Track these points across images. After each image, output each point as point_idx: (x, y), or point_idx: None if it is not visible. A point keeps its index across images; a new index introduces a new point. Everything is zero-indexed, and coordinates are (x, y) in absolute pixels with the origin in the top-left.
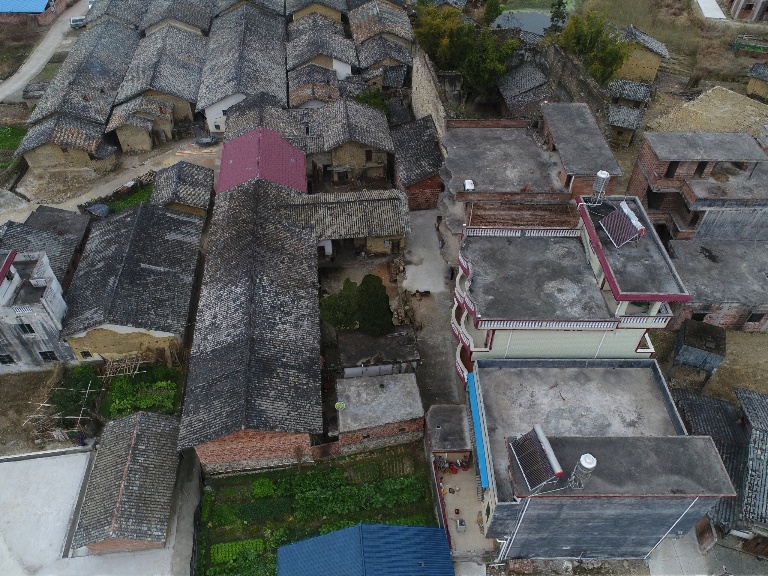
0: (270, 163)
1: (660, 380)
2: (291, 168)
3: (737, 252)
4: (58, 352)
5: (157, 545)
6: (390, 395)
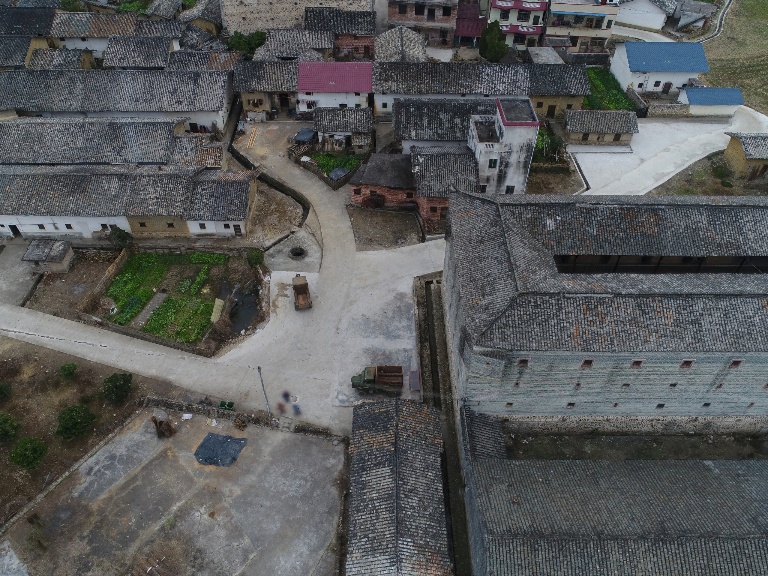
0: None
1: None
2: None
3: None
4: None
5: None
6: (542, 53)
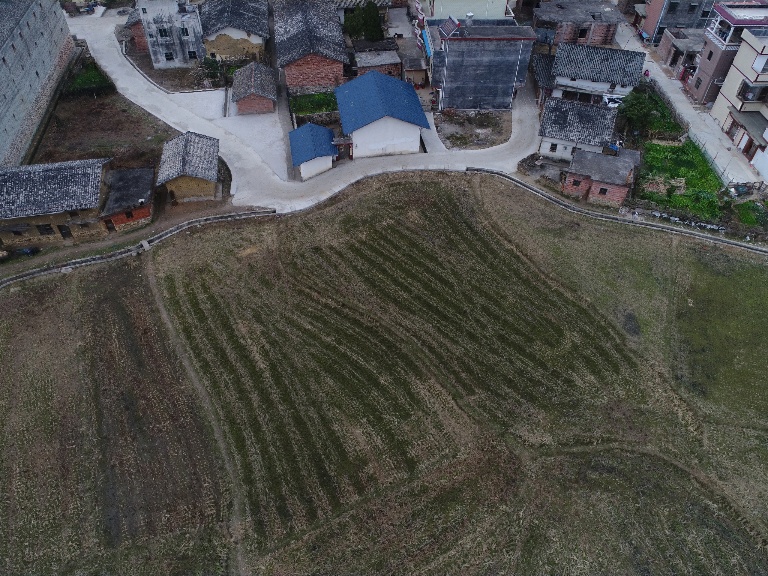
0: None
1: None
2: None
3: (576, 6)
4: (198, 52)
5: (271, 109)
6: (383, 57)
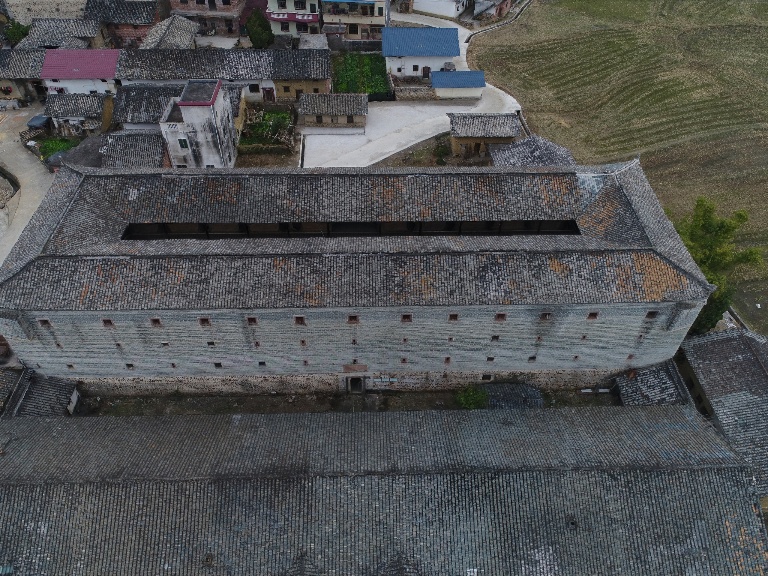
0: None
1: None
2: None
3: None
4: None
5: None
6: (312, 40)
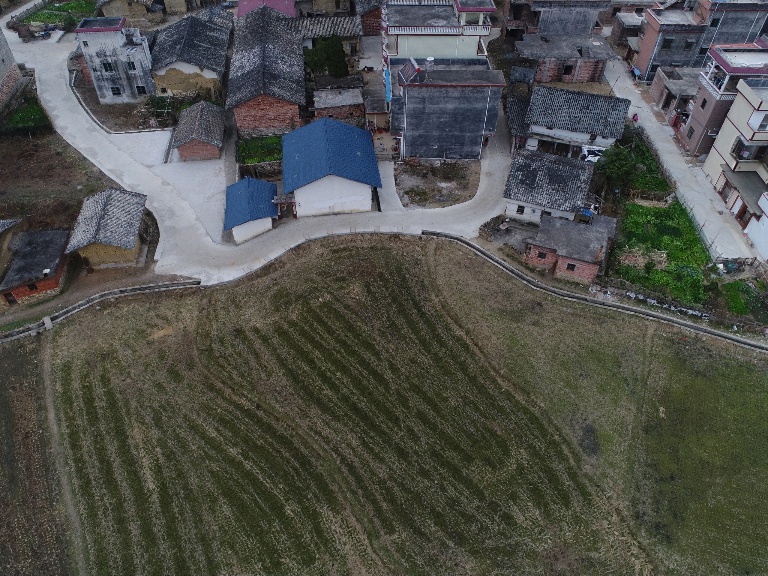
0: (272, 0)
1: (488, 66)
2: (285, 6)
3: (562, 39)
4: (147, 87)
5: (216, 156)
6: (345, 96)
